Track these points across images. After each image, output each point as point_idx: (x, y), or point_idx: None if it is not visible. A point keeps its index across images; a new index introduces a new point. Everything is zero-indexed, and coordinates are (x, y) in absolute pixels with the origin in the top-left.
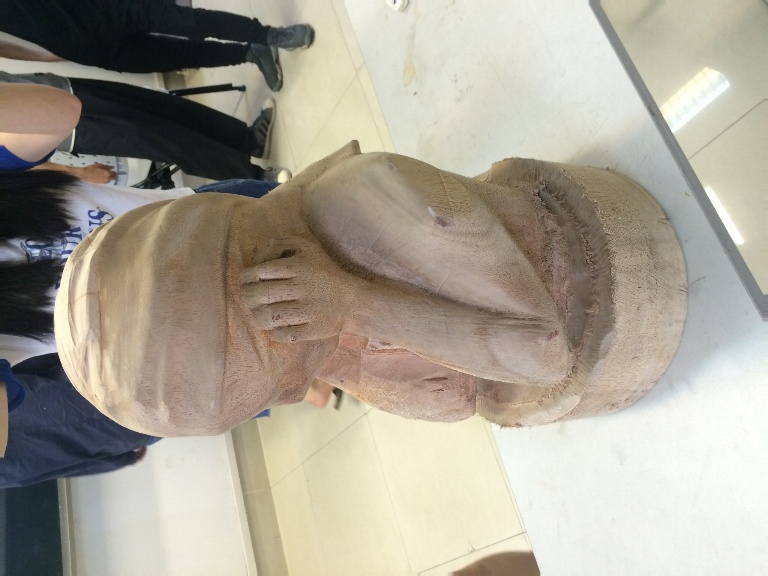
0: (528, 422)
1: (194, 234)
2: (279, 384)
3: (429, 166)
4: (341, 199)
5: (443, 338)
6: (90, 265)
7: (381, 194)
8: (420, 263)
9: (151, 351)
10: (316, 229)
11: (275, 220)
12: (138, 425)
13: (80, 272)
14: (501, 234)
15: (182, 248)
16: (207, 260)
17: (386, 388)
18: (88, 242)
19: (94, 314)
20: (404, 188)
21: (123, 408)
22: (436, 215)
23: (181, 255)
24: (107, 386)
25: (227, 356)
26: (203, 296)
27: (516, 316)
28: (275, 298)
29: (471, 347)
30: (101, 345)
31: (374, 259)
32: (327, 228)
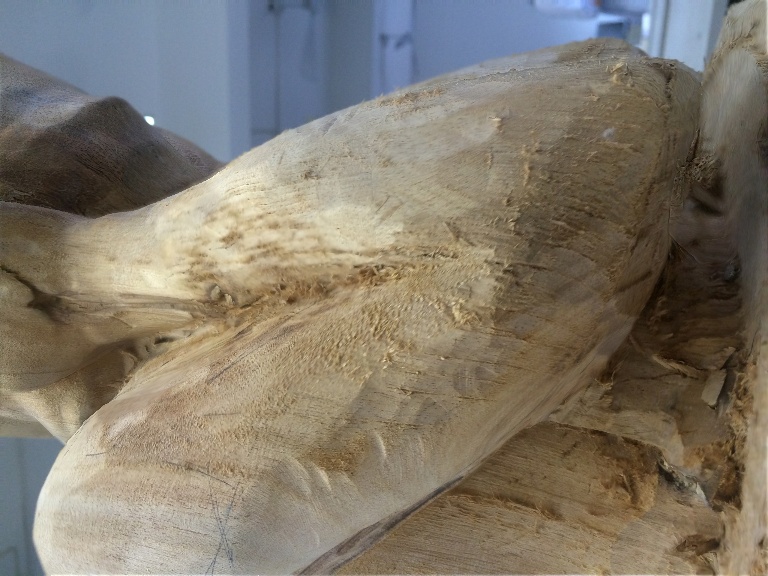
0: None
1: None
2: None
3: None
4: None
5: None
6: None
7: None
8: None
9: None
10: None
11: None
12: None
13: None
14: None
15: None
16: None
17: None
18: None
19: None
20: None
21: None
22: None
23: None
24: None
25: None
26: None
27: None
28: None
29: None
30: None
31: None
32: None
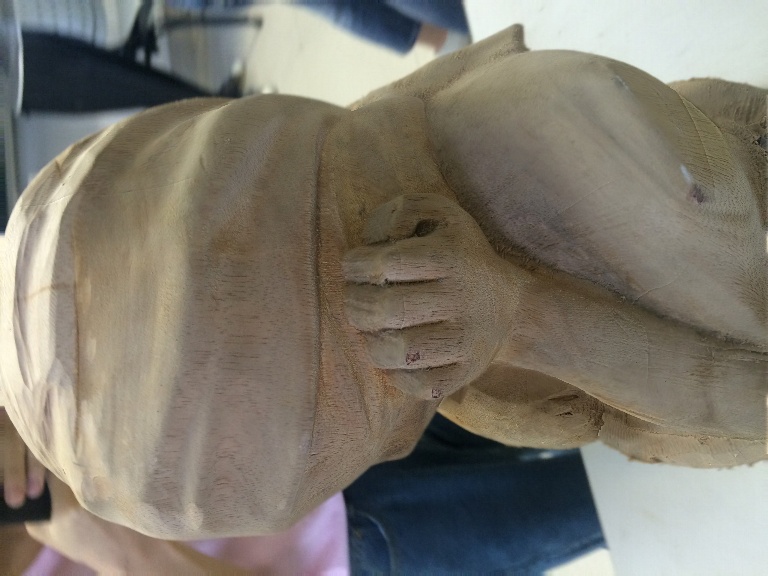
0: (673, 459)
1: (261, 178)
2: (382, 445)
3: (666, 87)
4: (510, 131)
5: (642, 377)
6: (60, 227)
7: (597, 132)
8: (633, 256)
9: (178, 417)
10: (452, 177)
11: (392, 157)
12: (142, 529)
13: (39, 238)
14: (757, 215)
15: (240, 206)
16: (287, 234)
17: (498, 411)
18: (57, 175)
19: (65, 329)
20: (642, 125)
21: (116, 506)
22: (693, 181)
23: (238, 221)
24: (87, 467)
25: (315, 420)
26: (280, 308)
27: (756, 348)
28: (412, 319)
29: (682, 394)
30: (77, 391)
31: (548, 238)
32: (472, 177)
